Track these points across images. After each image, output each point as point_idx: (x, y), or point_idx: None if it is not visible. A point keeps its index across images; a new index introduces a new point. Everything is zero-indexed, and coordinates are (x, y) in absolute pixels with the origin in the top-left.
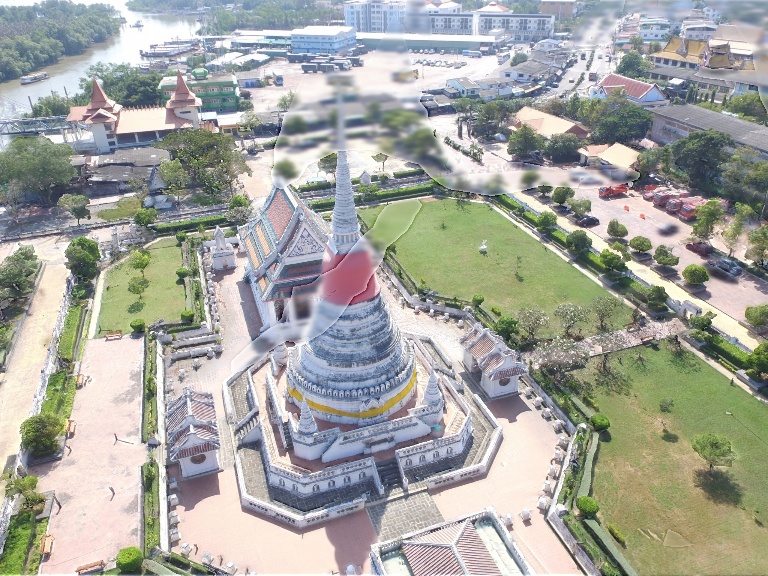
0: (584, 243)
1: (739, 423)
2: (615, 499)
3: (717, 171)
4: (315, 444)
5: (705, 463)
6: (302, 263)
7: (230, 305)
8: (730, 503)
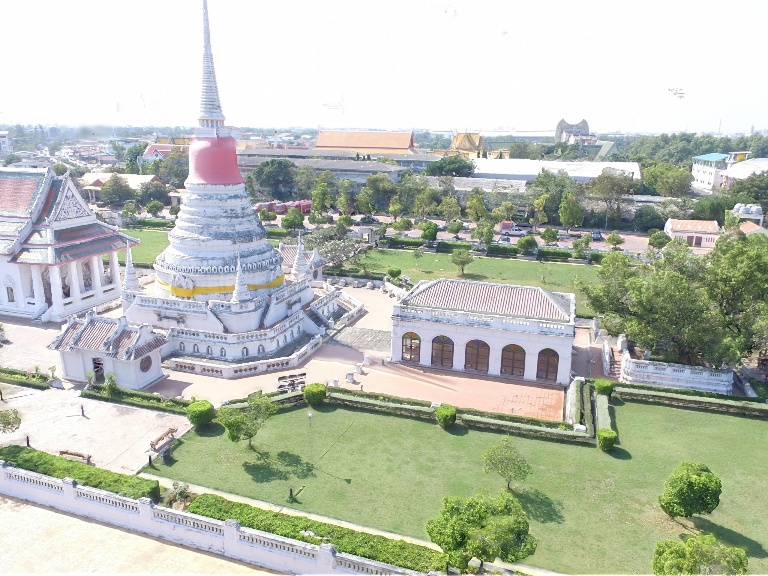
0: None
1: None
2: None
3: (291, 186)
4: (257, 310)
5: (457, 273)
6: (70, 228)
7: None
8: None
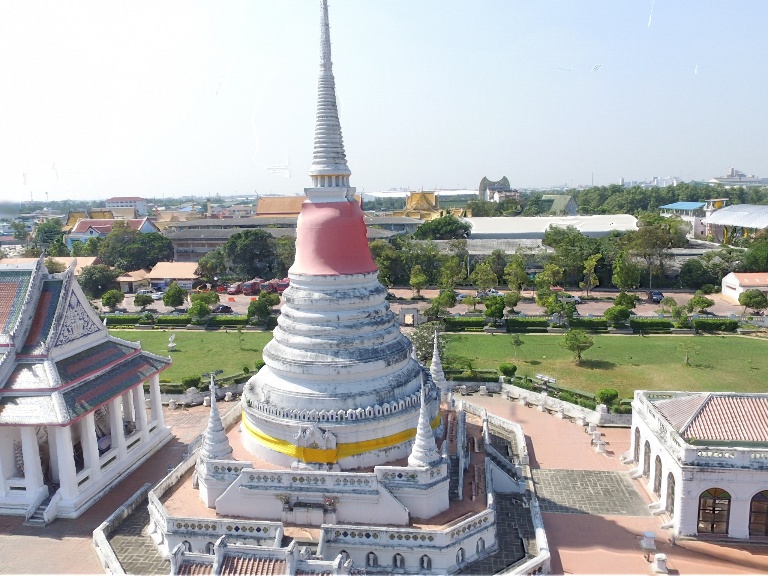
0: (267, 310)
1: (535, 344)
2: (595, 393)
3: (270, 260)
4: (449, 473)
5: None
6: (77, 355)
7: None
8: (614, 366)
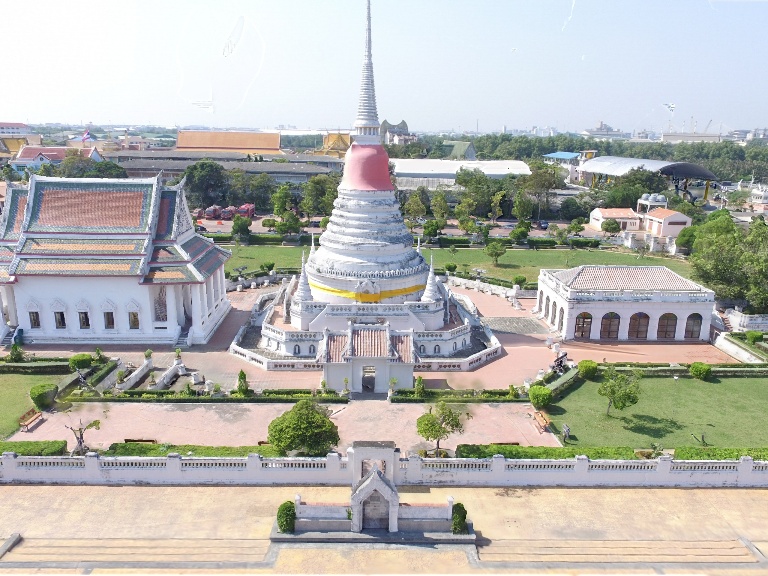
0: None
1: None
2: None
3: (223, 190)
4: None
5: (491, 264)
6: (187, 243)
7: None
8: None
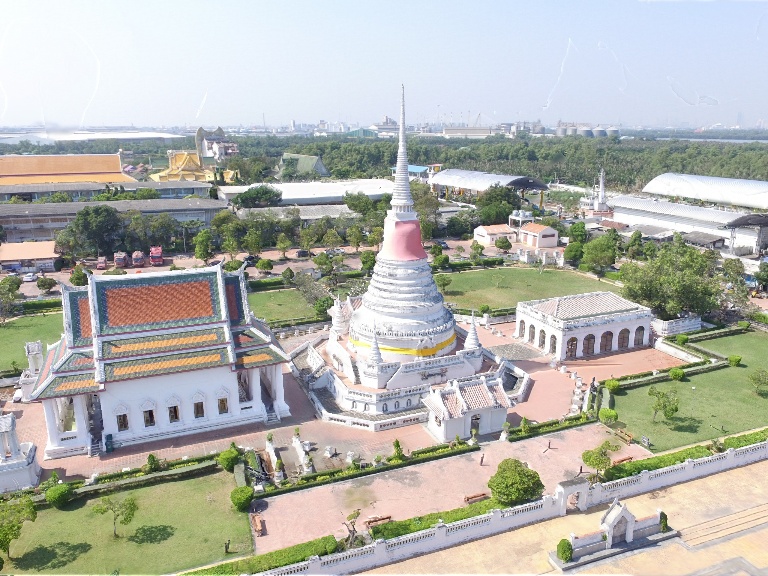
0: None
1: None
2: None
3: (121, 234)
4: None
5: None
6: None
7: (178, 455)
8: None
